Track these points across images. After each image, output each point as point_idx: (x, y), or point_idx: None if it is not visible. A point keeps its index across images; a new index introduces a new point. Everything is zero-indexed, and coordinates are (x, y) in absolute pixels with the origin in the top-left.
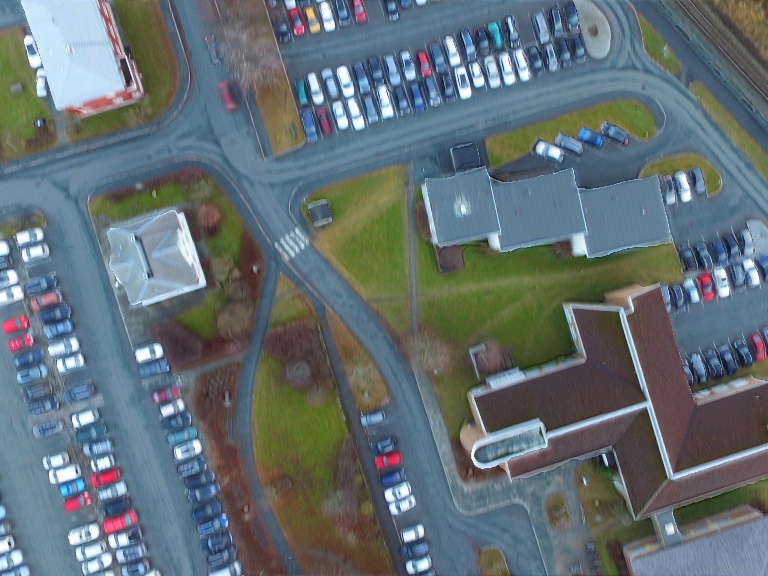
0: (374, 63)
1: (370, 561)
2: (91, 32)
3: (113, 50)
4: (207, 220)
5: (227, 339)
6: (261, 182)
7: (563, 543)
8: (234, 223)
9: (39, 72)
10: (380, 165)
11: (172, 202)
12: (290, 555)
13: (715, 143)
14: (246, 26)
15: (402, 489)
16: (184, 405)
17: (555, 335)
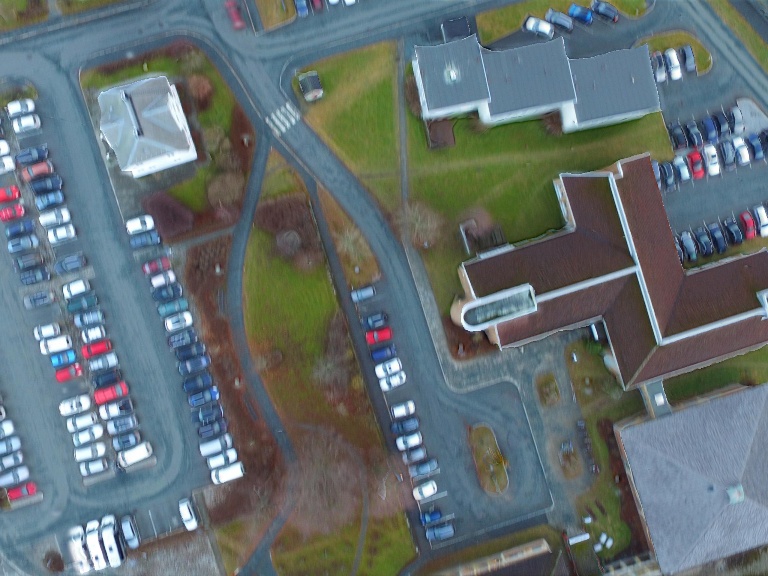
0: None
1: (361, 435)
2: None
3: None
4: (198, 91)
5: (218, 210)
6: (252, 57)
7: (553, 421)
8: (225, 97)
9: None
10: (371, 41)
11: None
12: (281, 428)
13: (705, 21)
14: None
15: (393, 364)
16: (175, 277)
17: (545, 212)
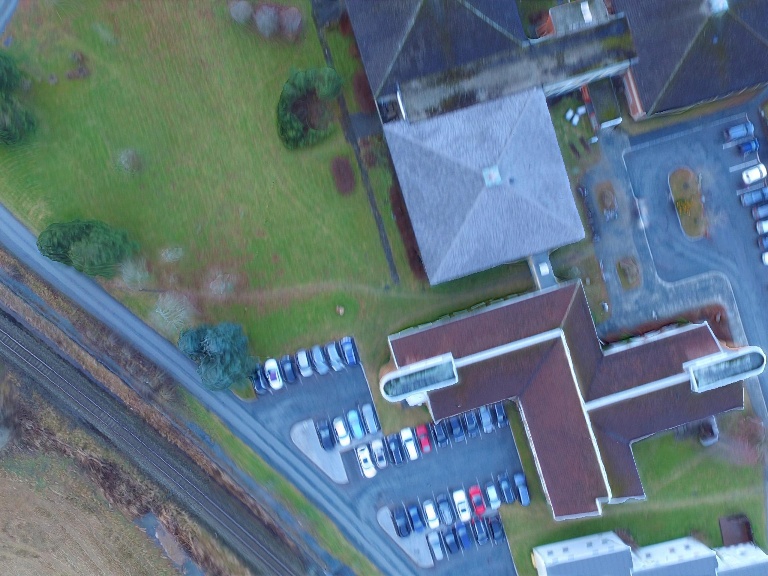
0: None
1: None
2: None
3: None
4: None
5: None
6: None
7: (623, 241)
8: None
9: None
10: None
11: None
12: None
13: None
14: None
15: None
16: None
17: None
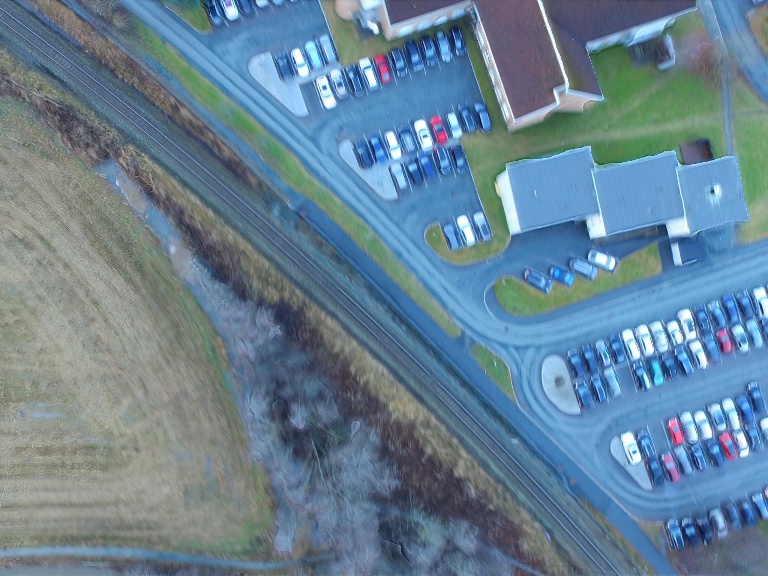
0: None
1: None
2: None
3: None
4: None
5: None
6: None
7: None
8: None
9: None
10: (762, 243)
11: None
12: None
13: (434, 276)
14: None
15: None
16: None
17: None
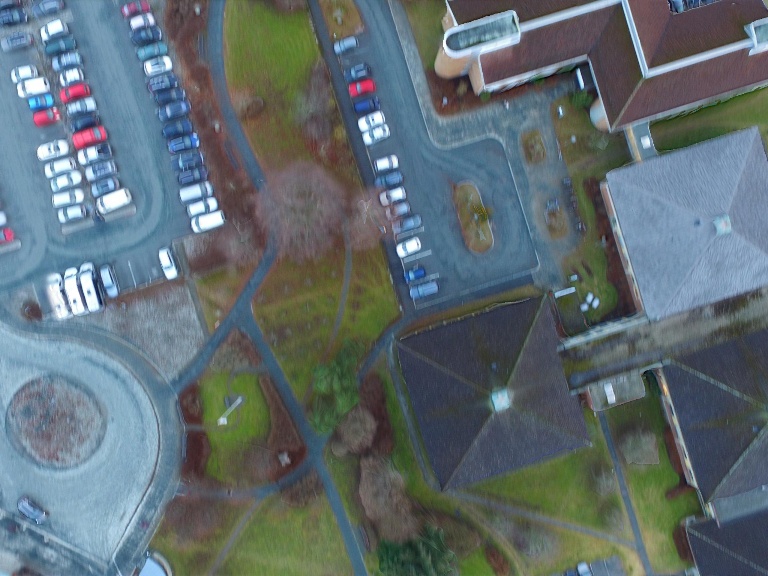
0: None
1: (343, 186)
2: None
3: None
4: None
5: None
6: None
7: (539, 179)
8: None
9: None
10: None
11: None
12: (262, 178)
13: None
14: None
15: (376, 116)
16: (154, 21)
17: None
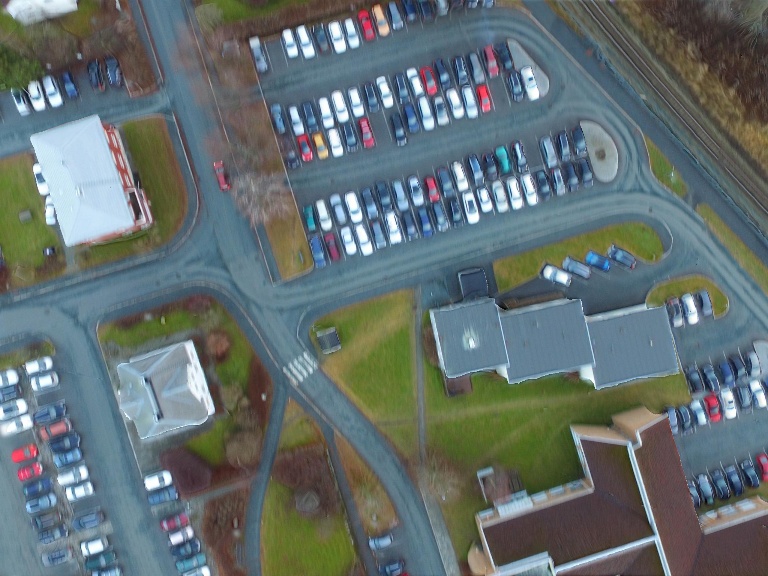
0: (382, 189)
1: None
2: (101, 170)
3: (122, 184)
4: (216, 349)
5: (236, 467)
6: (269, 307)
7: None
8: (243, 349)
9: (48, 199)
10: (388, 289)
11: (181, 328)
12: None
13: (722, 265)
14: (254, 152)
15: None
16: (193, 532)
17: (562, 457)
